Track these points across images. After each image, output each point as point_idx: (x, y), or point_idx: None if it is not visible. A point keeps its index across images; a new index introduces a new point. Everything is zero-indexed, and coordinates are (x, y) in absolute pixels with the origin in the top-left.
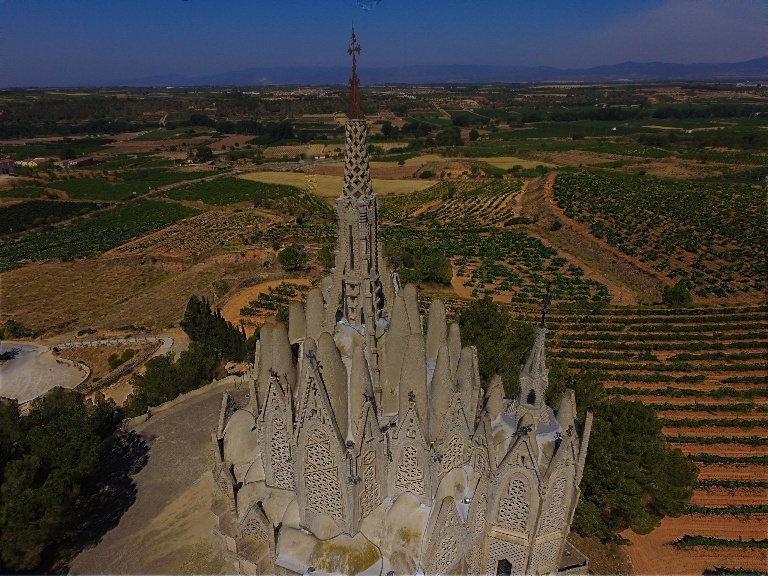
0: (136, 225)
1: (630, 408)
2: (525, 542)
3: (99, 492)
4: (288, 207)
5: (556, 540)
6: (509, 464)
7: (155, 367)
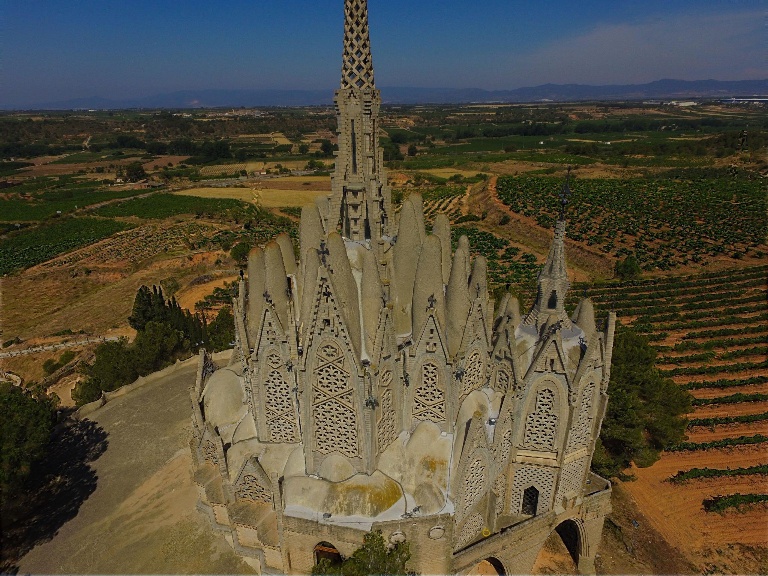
0: (63, 242)
1: (625, 338)
2: (553, 462)
3: (49, 484)
4: (233, 215)
5: (582, 459)
6: (536, 372)
7: (106, 353)
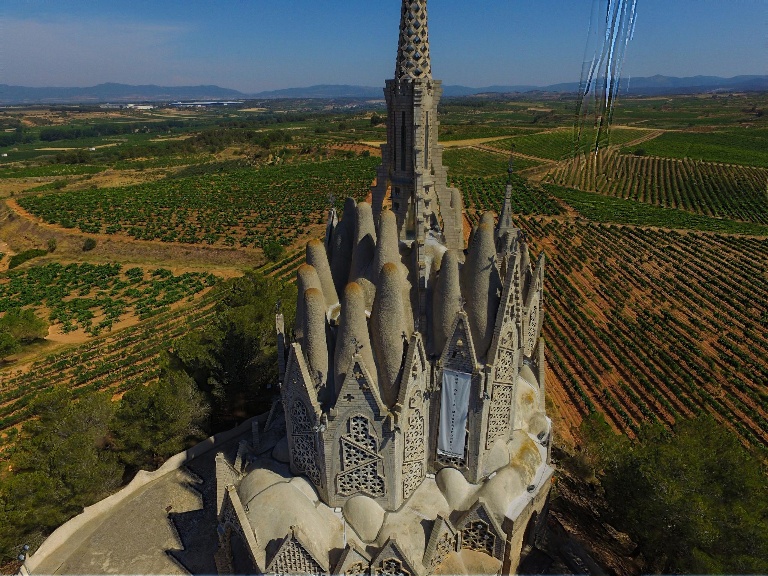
0: None
1: None
2: None
3: None
4: None
5: None
6: None
7: None
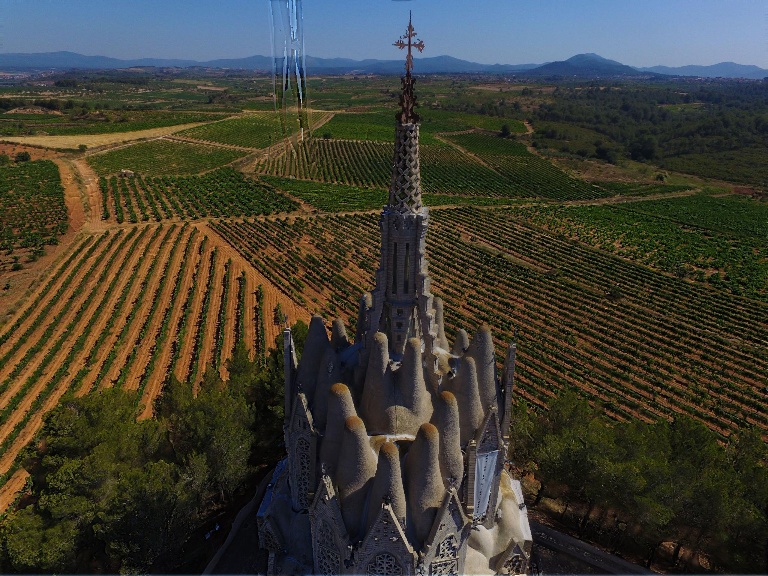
0: None
1: (301, 330)
2: None
3: None
4: None
5: None
6: None
7: None
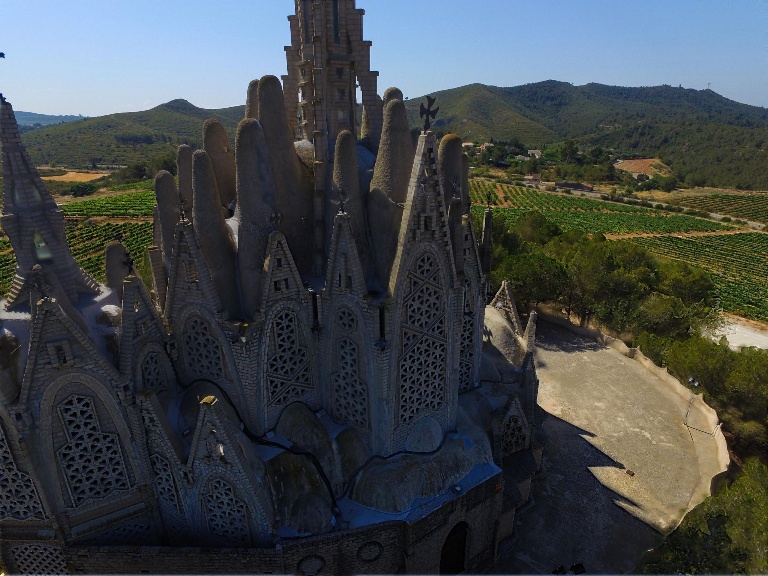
0: None
1: None
2: None
3: None
4: None
5: None
6: None
7: (738, 353)
